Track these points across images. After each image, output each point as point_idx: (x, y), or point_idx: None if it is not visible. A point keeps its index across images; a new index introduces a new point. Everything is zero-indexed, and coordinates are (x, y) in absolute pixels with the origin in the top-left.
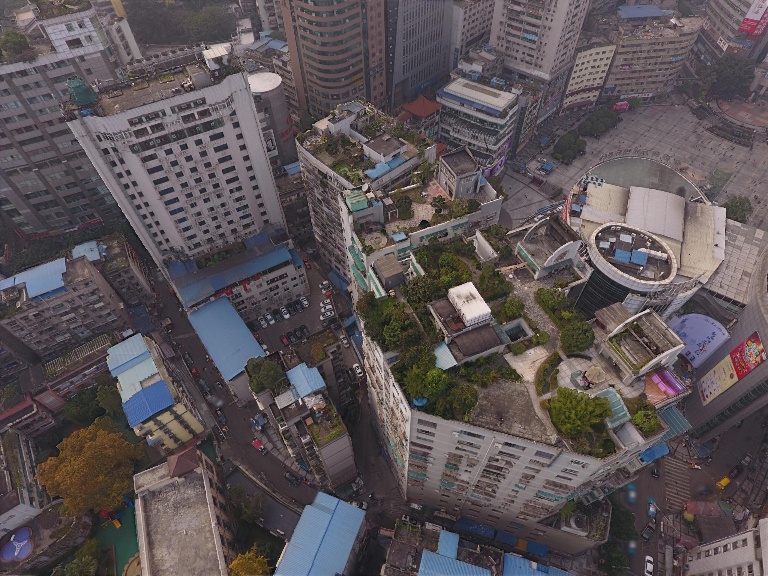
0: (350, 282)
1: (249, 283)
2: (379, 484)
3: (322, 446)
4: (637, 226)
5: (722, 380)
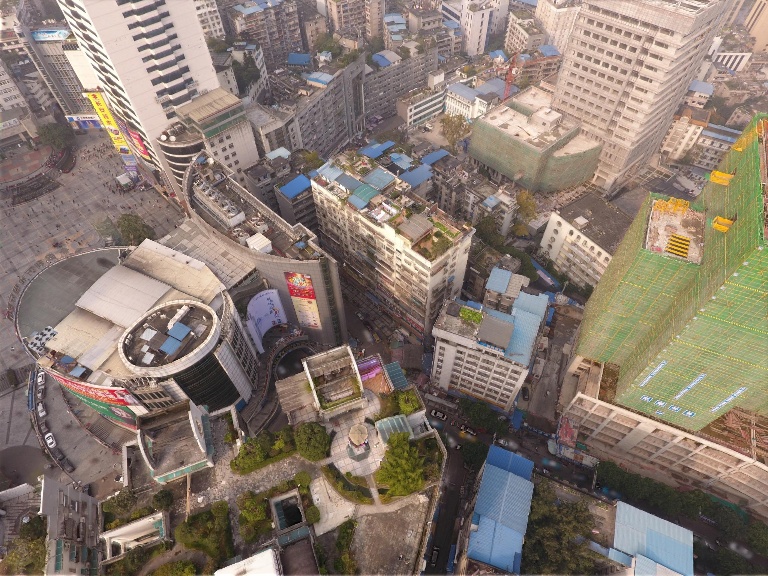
0: None
1: None
2: None
3: None
4: (135, 318)
5: (309, 310)
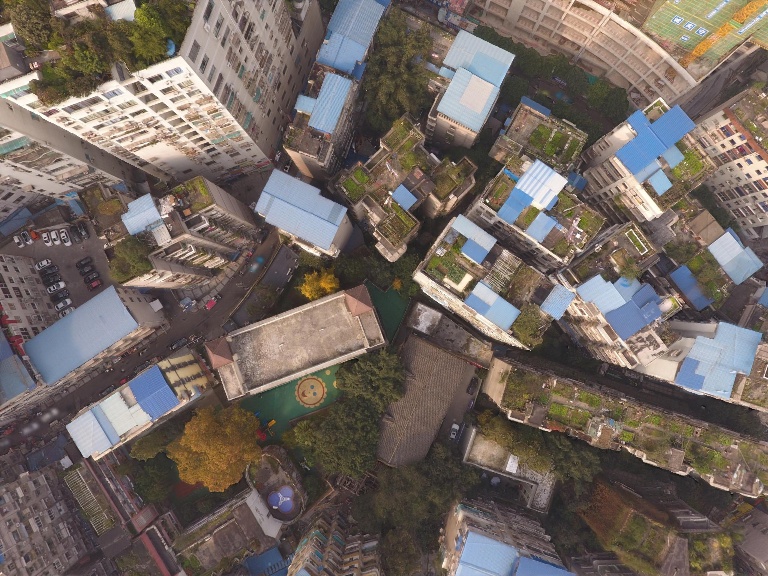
0: (17, 182)
1: (6, 316)
2: (257, 190)
3: (213, 200)
4: None
5: None
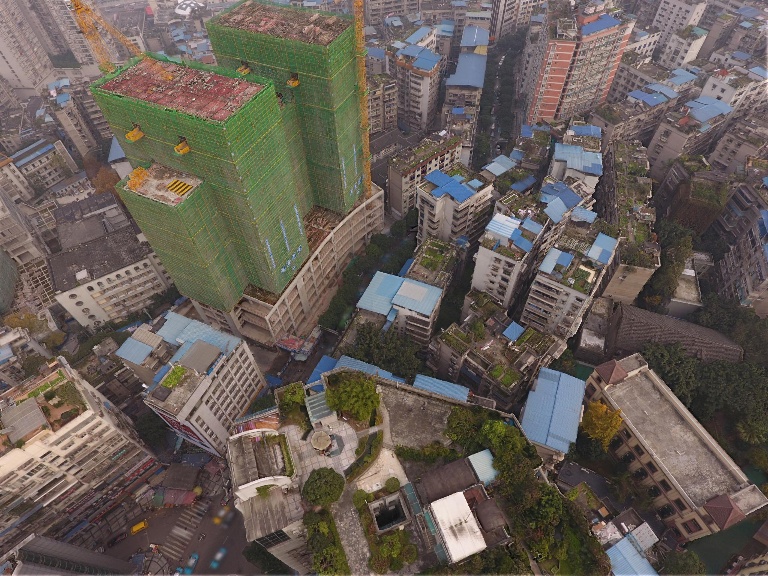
0: None
1: None
2: None
3: (580, 484)
4: None
5: None
